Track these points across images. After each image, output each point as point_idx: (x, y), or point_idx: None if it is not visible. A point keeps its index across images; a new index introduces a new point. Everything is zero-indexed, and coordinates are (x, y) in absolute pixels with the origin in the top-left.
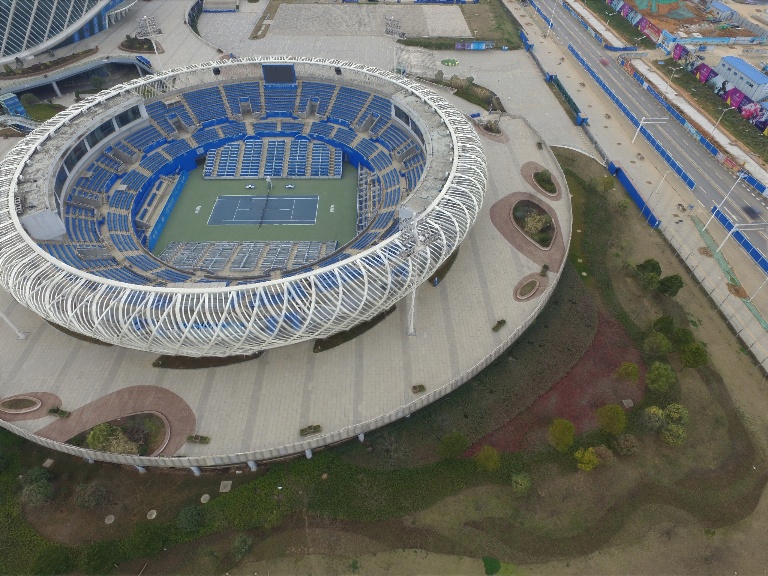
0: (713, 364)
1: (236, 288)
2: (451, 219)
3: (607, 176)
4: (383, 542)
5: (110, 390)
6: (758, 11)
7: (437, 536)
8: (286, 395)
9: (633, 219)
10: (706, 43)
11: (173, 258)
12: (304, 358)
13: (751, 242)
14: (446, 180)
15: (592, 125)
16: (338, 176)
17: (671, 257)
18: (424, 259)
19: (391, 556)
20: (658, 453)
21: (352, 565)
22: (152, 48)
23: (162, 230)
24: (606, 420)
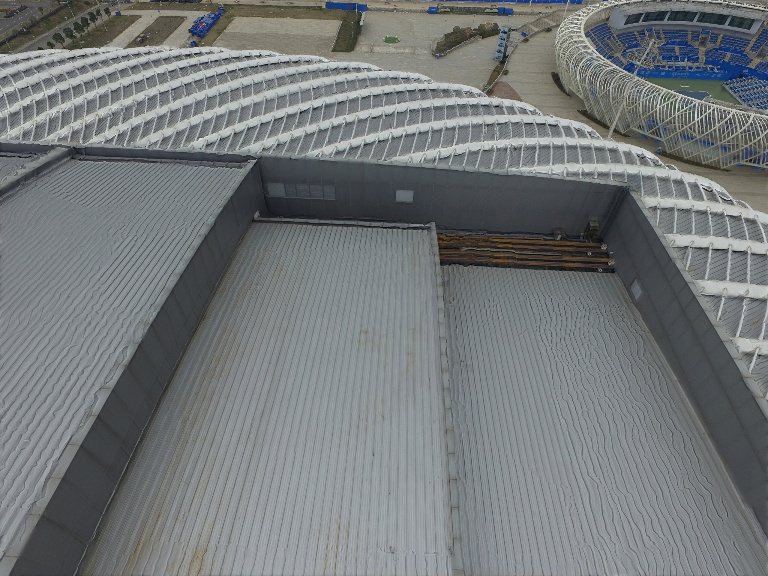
0: None
1: None
2: None
3: None
4: None
5: None
6: None
7: None
8: None
9: None
10: None
11: None
12: None
13: None
14: (727, 6)
15: None
16: None
17: None
18: None
19: None
20: None
21: None
22: None
23: None
24: None
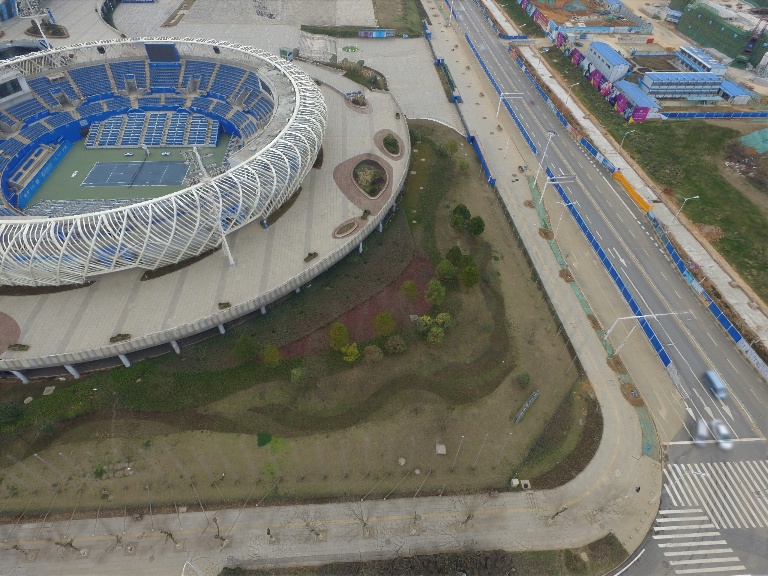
0: (500, 288)
1: (56, 219)
2: (269, 166)
3: (462, 144)
4: (176, 426)
5: None
6: (647, 5)
7: (222, 419)
8: (107, 313)
9: (474, 178)
10: (589, 32)
11: None
12: (131, 285)
13: (572, 196)
14: None
15: (465, 102)
16: (213, 145)
17: (497, 208)
18: (236, 197)
19: (180, 436)
20: (425, 353)
21: (145, 444)
22: (57, 33)
23: (36, 191)
24: None
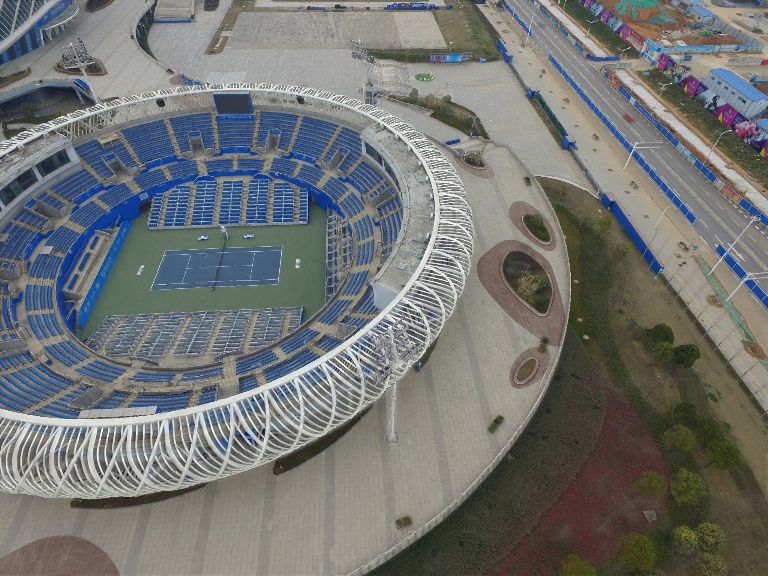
0: (740, 452)
1: (168, 416)
2: (435, 298)
3: (601, 211)
4: None
5: (13, 546)
6: (739, 15)
7: None
8: (239, 541)
9: (633, 263)
10: (690, 51)
11: (107, 339)
12: (262, 483)
13: (762, 287)
14: (427, 243)
15: (580, 148)
16: (304, 222)
17: (679, 310)
18: None
19: None
20: None
21: None
22: (92, 69)
23: (97, 299)
24: (631, 557)
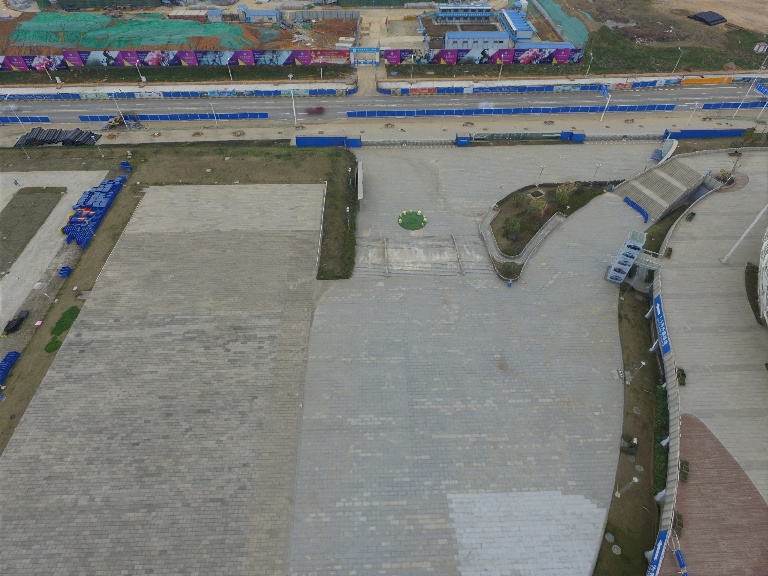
0: None
1: None
2: None
3: None
4: None
5: None
6: (261, 4)
7: None
8: None
9: None
10: None
11: None
12: None
13: None
14: None
15: None
16: None
17: None
18: None
19: None
20: None
21: None
22: None
23: None
24: None
